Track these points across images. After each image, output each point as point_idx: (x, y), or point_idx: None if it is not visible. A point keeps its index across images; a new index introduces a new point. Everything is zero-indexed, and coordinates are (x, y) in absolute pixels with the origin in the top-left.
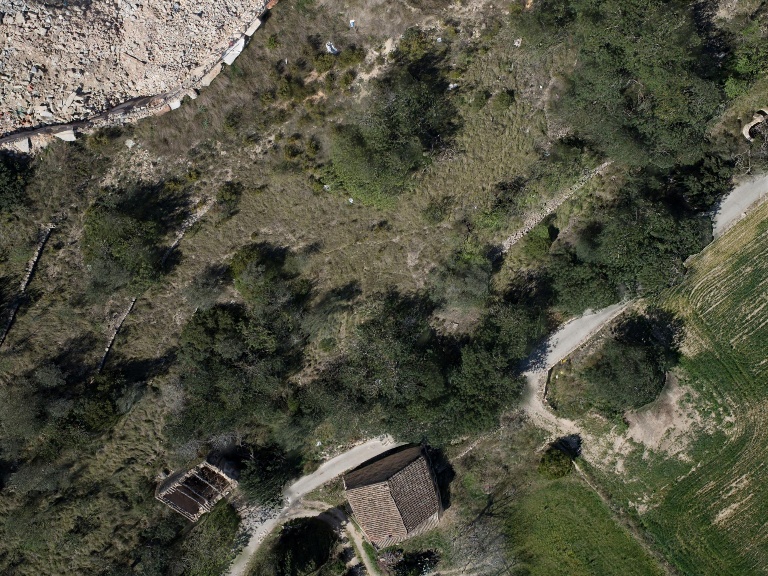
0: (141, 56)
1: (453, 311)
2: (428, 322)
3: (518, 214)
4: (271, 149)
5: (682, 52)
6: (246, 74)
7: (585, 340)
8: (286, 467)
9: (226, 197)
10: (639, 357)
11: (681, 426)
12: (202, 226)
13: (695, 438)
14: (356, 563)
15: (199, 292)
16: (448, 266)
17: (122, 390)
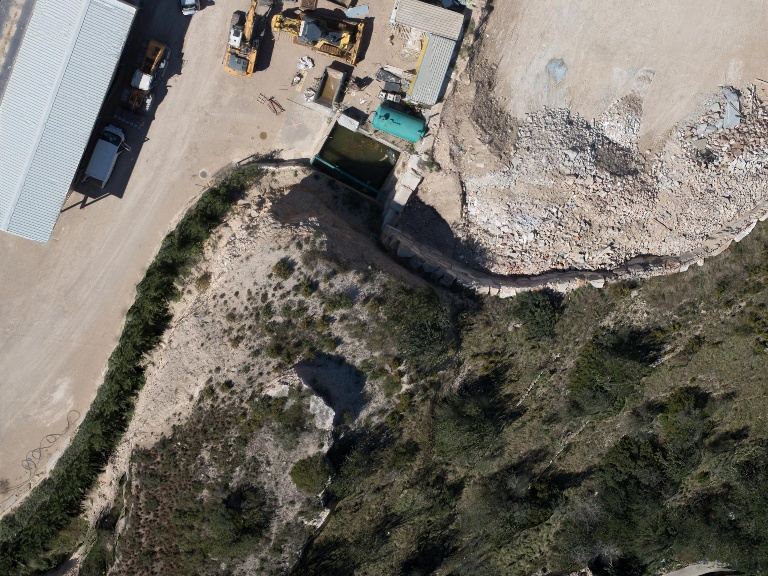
0: (670, 224)
1: None
2: None
3: None
4: (739, 313)
5: None
6: (743, 250)
7: None
8: None
9: (695, 349)
10: None
11: None
12: None
13: None
14: None
15: (638, 423)
16: None
17: (558, 500)
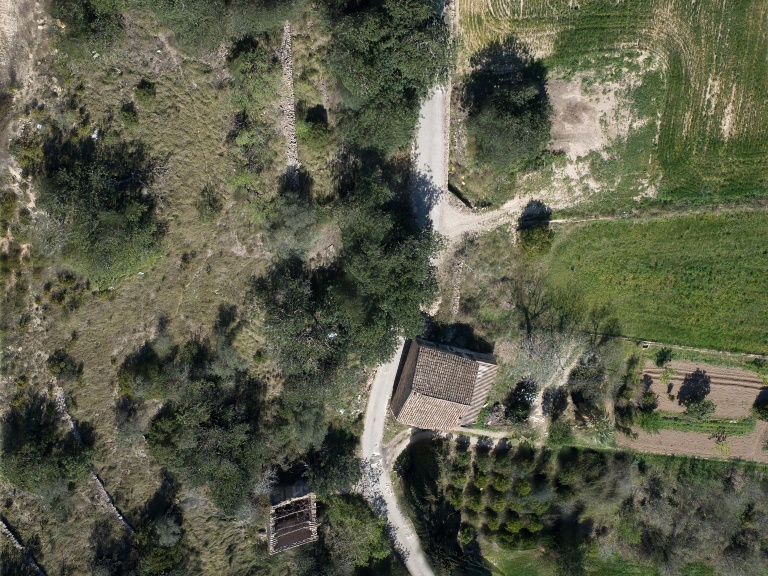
0: None
1: (316, 243)
2: (308, 269)
3: (271, 136)
4: (44, 312)
5: None
6: None
7: (448, 141)
8: (335, 450)
9: (57, 371)
10: (491, 117)
11: (608, 106)
12: (74, 396)
13: (631, 101)
14: (476, 441)
15: (126, 431)
16: (266, 228)
17: (157, 532)
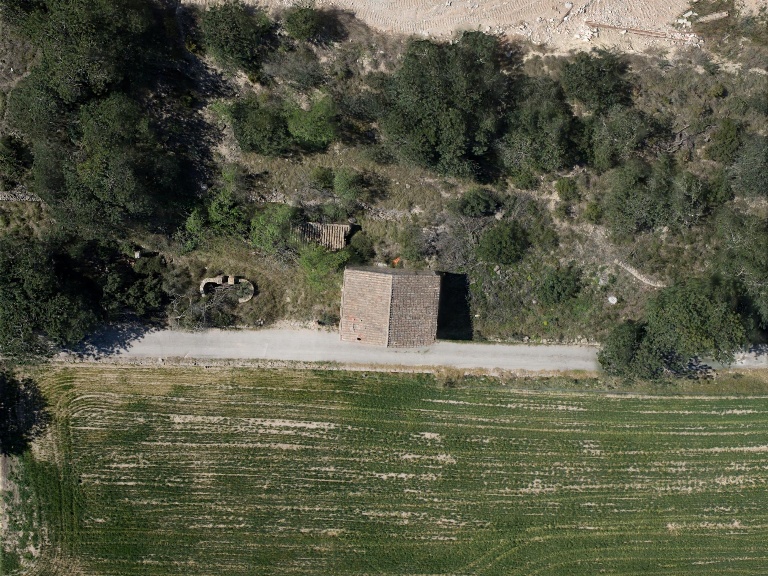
0: None
1: None
2: None
3: None
4: None
5: (114, 118)
6: None
7: None
8: None
9: None
10: None
11: None
12: None
13: None
14: None
15: None
16: None
17: None
